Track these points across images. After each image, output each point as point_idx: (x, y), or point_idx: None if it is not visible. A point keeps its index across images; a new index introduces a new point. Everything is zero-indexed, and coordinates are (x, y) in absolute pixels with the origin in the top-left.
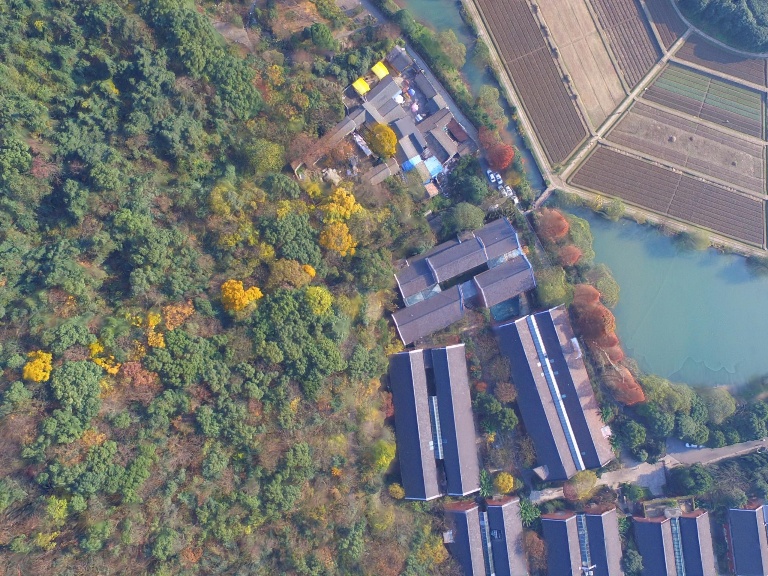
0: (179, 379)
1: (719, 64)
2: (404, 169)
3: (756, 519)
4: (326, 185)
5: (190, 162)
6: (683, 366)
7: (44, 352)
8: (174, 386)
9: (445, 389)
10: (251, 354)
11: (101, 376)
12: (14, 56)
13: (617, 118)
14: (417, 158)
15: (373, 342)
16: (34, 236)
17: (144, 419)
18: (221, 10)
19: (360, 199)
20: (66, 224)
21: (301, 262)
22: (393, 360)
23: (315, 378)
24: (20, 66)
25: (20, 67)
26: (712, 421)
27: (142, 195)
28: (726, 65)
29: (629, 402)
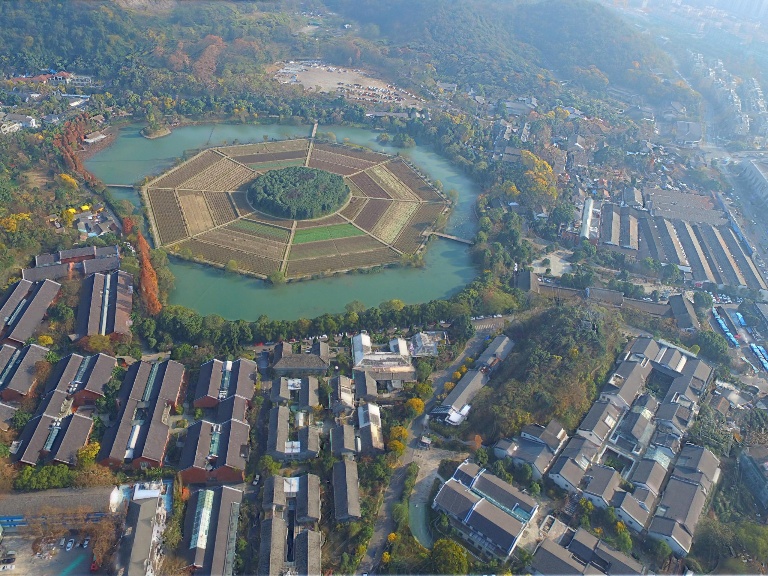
0: None
1: (268, 221)
2: None
3: (213, 364)
4: None
5: None
6: None
7: None
8: None
9: (33, 295)
10: None
11: None
12: None
13: None
14: (84, 230)
15: None
16: None
17: None
18: None
19: None
20: None
21: None
22: None
23: None
24: None
25: None
26: None
27: None
28: (272, 221)
29: (148, 306)
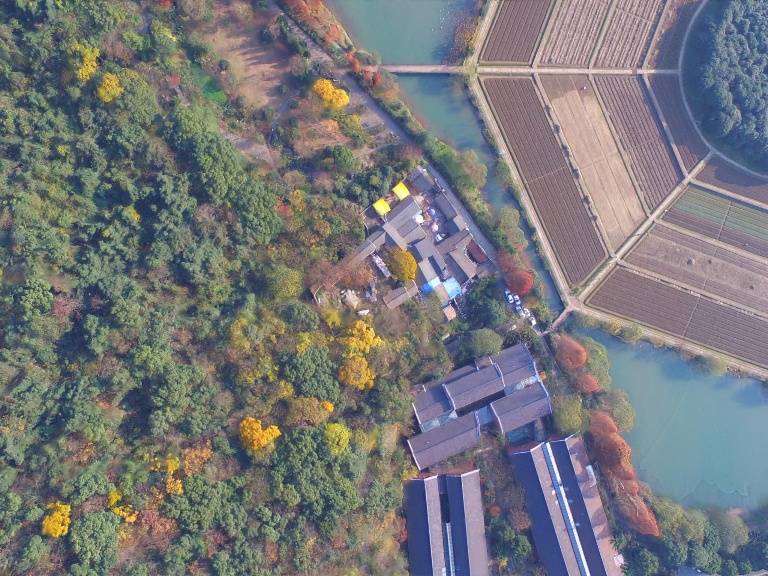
0: (196, 525)
1: (740, 187)
2: (423, 291)
3: None
4: (345, 312)
5: (210, 289)
6: (696, 489)
7: (63, 504)
8: (191, 531)
9: (459, 516)
10: (268, 497)
11: (119, 525)
12: (36, 182)
13: (636, 240)
14: (436, 280)
15: (389, 477)
16: (53, 370)
17: (160, 565)
18: (243, 126)
19: (379, 328)
20: (85, 359)
21: (320, 399)
22: (408, 485)
23: (331, 519)
24: (42, 191)
25: (42, 192)
26: (725, 549)
27: (162, 330)
28: (747, 188)
29: (643, 533)
